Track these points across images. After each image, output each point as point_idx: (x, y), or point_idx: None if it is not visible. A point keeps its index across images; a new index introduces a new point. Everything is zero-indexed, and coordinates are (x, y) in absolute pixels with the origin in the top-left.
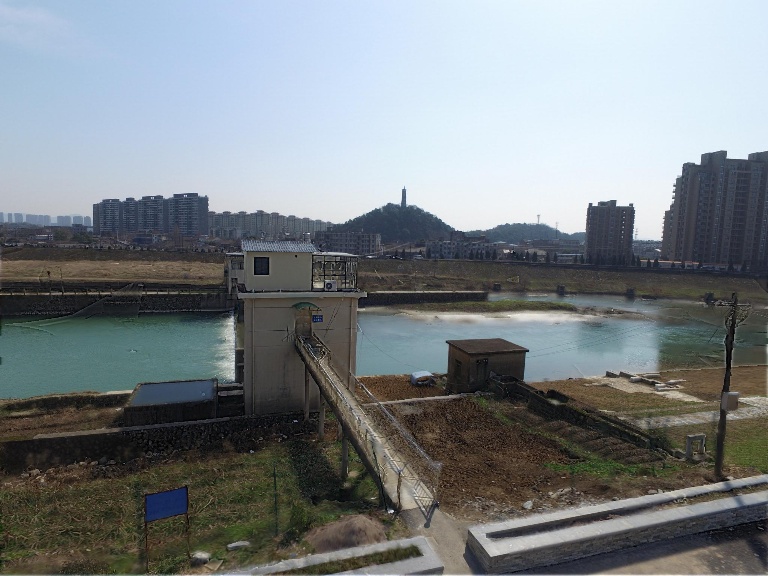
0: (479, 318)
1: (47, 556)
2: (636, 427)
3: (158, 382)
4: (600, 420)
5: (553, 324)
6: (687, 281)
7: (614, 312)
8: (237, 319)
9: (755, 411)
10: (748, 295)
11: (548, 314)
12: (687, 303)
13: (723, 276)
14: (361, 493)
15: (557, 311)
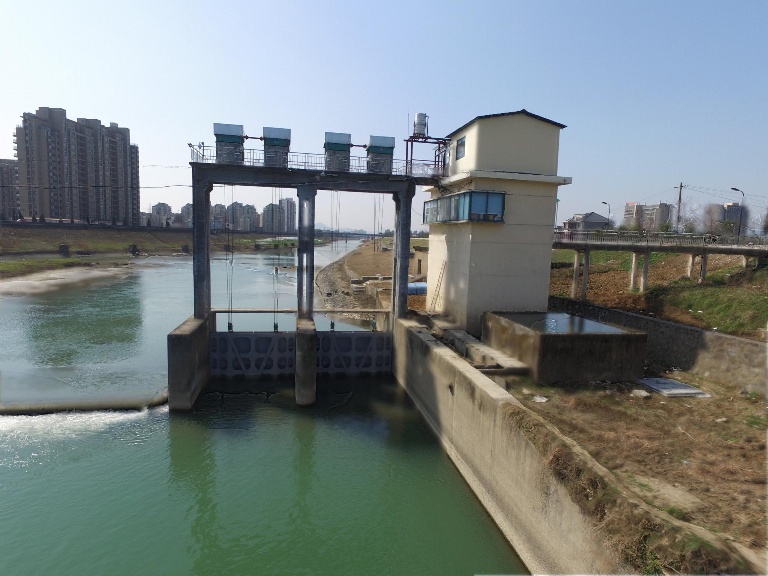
0: (32, 283)
1: None
2: None
3: None
4: (563, 263)
5: (123, 277)
6: (99, 236)
7: (120, 264)
8: (487, 221)
9: None
10: (154, 245)
11: (78, 271)
12: (115, 256)
13: (124, 230)
14: (720, 279)
15: (76, 268)
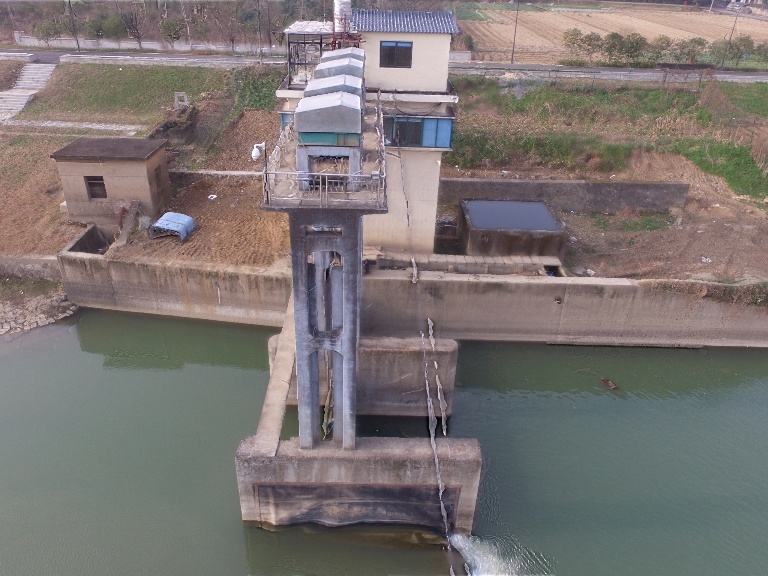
0: None
1: (489, 115)
2: (181, 108)
3: (544, 230)
4: None
5: None
6: None
7: None
8: None
9: (16, 122)
10: None
11: None
12: None
13: None
14: None
15: None
